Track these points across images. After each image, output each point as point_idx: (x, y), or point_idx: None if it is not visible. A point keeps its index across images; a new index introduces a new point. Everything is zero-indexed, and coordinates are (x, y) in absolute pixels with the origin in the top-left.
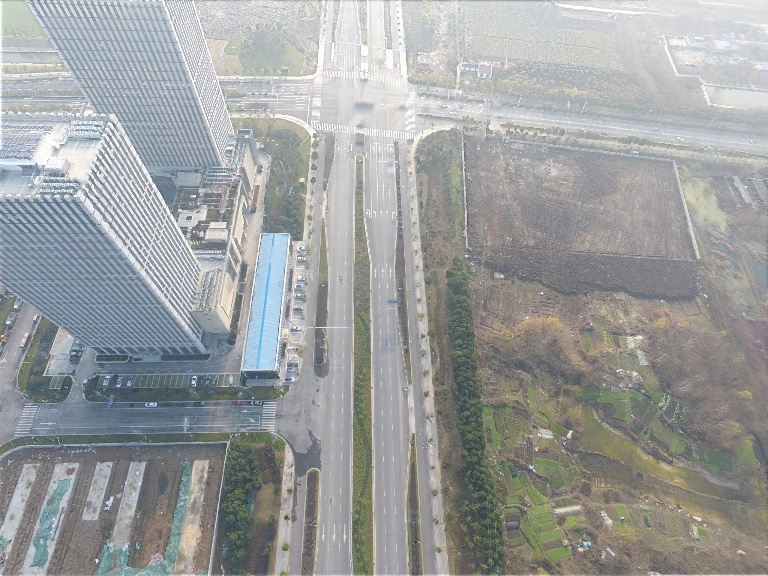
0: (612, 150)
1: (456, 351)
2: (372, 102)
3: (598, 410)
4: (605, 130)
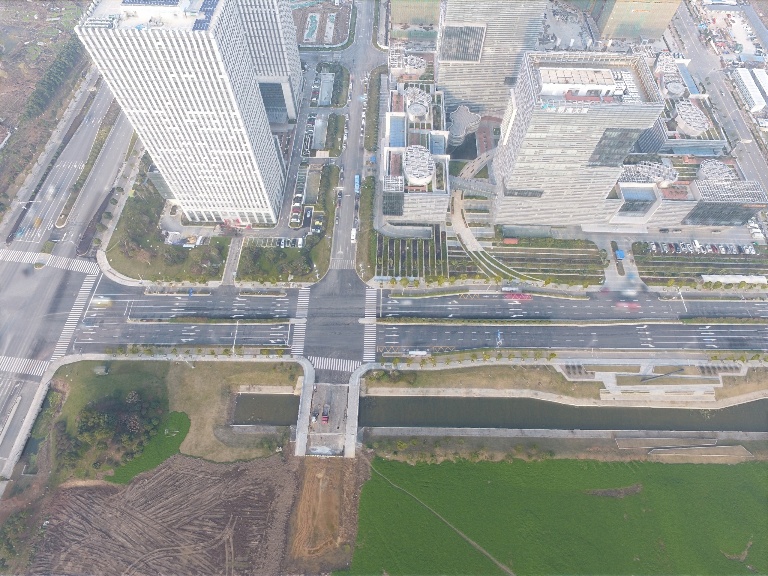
0: None
1: (65, 61)
2: (2, 307)
3: None
4: None
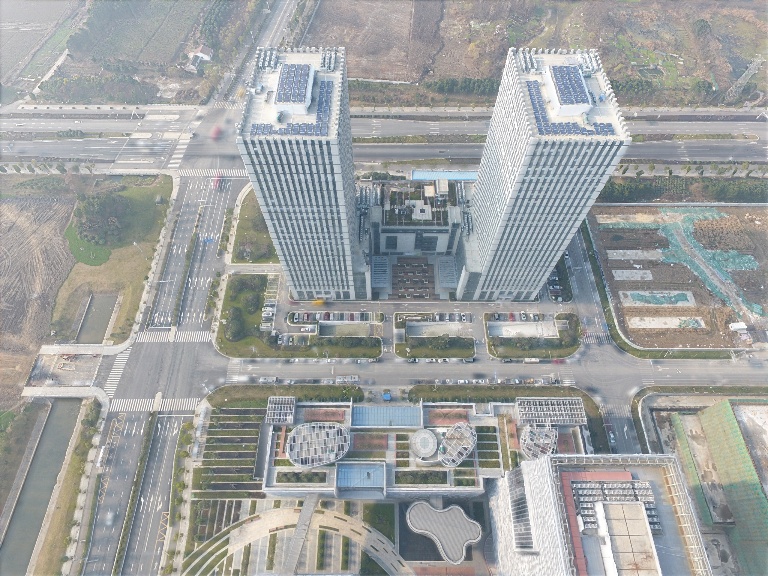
0: (315, 3)
1: None
2: (231, 131)
3: (521, 45)
4: (291, 4)
